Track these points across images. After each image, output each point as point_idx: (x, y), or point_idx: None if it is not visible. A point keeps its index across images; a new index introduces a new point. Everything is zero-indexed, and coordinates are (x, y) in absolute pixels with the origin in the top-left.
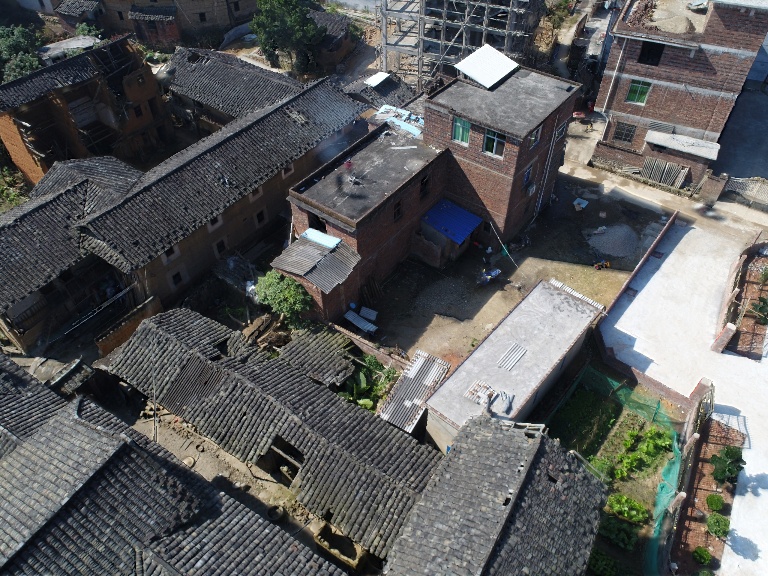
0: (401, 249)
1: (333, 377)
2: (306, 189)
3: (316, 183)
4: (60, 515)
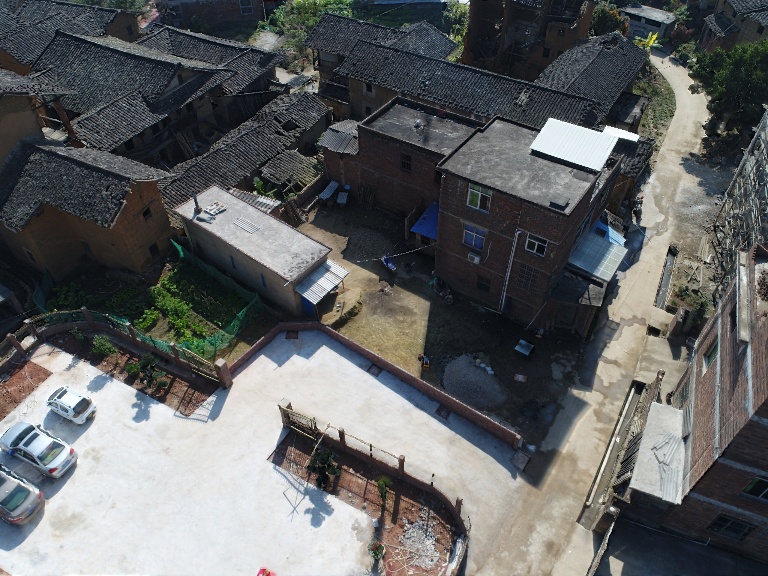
0: (409, 204)
1: (268, 172)
2: (406, 106)
3: (414, 109)
4: (149, 60)
